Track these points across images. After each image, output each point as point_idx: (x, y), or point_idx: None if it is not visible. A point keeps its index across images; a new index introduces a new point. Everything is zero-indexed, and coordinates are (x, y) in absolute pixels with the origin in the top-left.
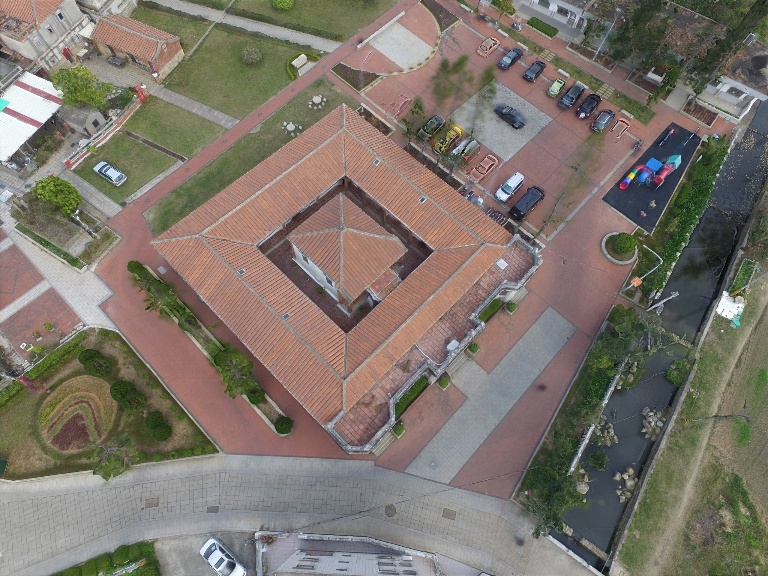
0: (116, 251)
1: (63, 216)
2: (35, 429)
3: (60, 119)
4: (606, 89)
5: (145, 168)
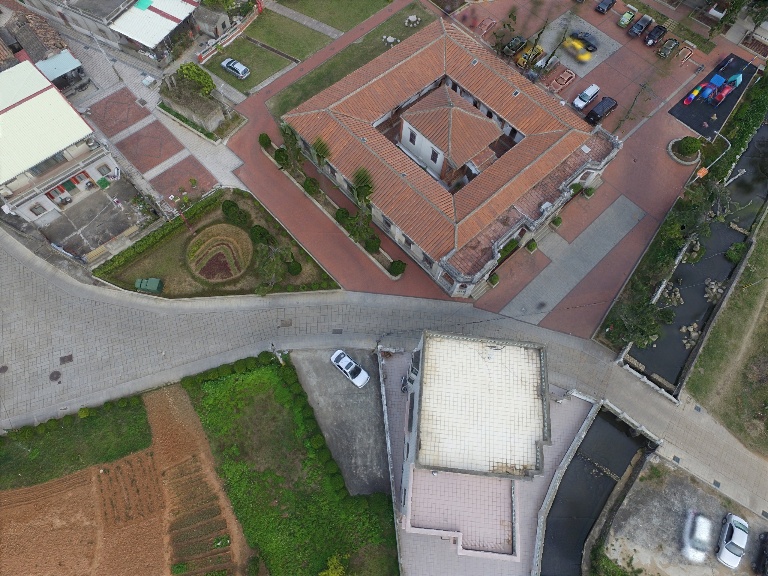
0: (244, 130)
1: (203, 95)
2: (185, 262)
3: (193, 20)
4: (671, 23)
5: (264, 67)
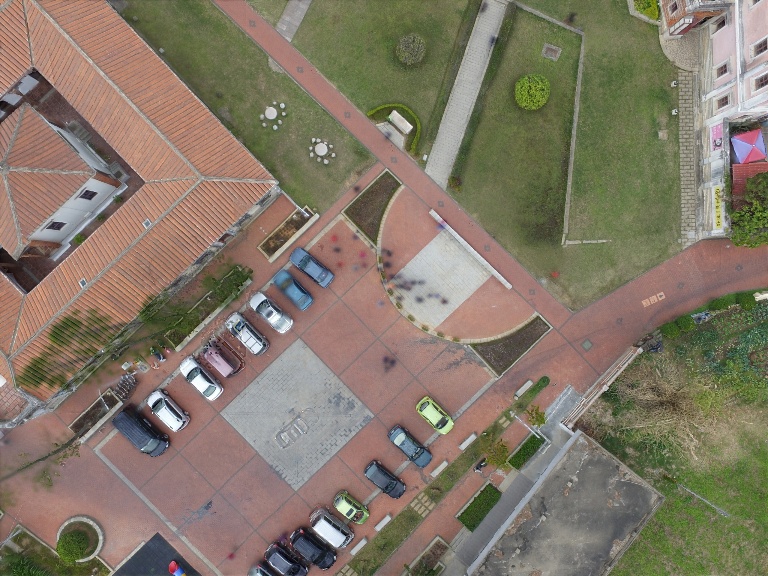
0: None
1: None
2: None
3: None
4: None
5: None
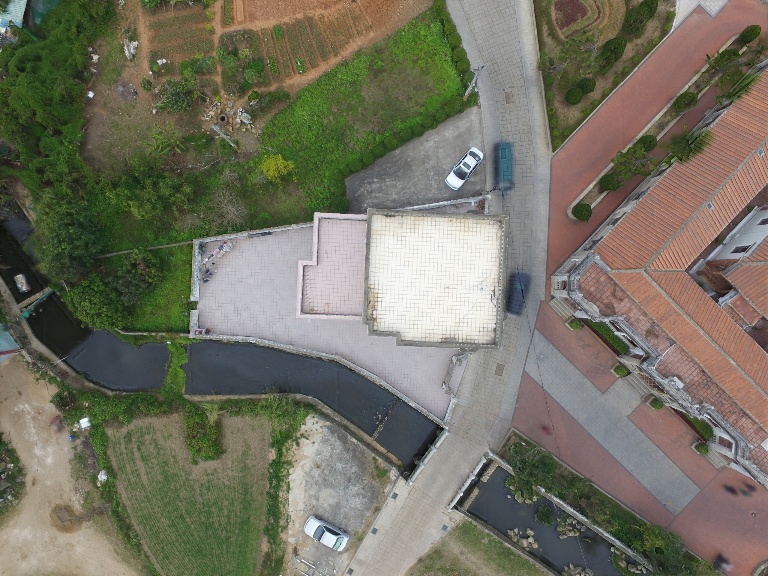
0: (764, 8)
1: None
2: None
3: None
4: None
5: None
